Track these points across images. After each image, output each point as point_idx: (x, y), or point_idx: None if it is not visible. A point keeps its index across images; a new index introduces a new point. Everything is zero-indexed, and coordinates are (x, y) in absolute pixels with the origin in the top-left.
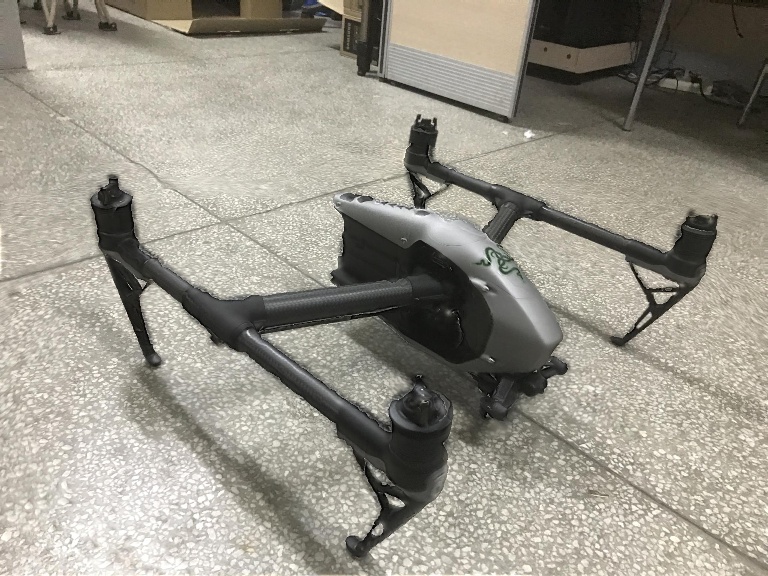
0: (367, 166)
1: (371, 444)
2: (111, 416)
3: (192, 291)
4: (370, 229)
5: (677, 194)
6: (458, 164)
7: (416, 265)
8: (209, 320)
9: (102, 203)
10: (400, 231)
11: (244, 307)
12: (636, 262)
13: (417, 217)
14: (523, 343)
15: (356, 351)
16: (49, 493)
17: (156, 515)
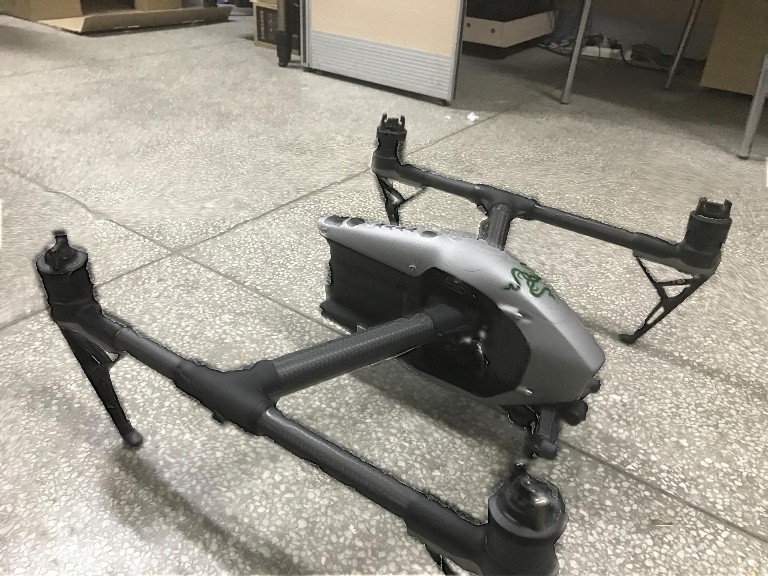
0: (316, 169)
1: (456, 543)
2: (97, 521)
3: (185, 366)
4: (368, 257)
5: (632, 167)
6: (410, 156)
7: (429, 294)
8: (216, 402)
9: (52, 268)
10: (406, 257)
11: (254, 379)
12: (645, 257)
13: (424, 240)
14: (566, 371)
15: (361, 391)
16: None
17: None
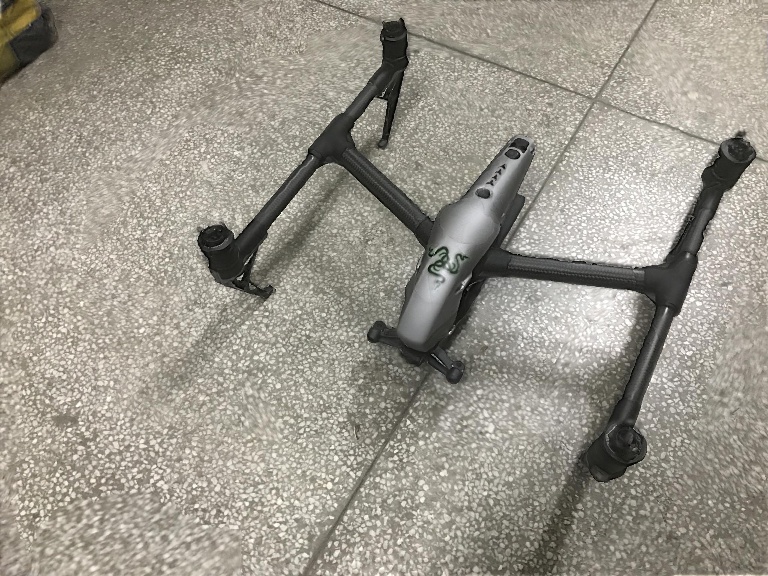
0: None
1: None
2: None
3: (343, 116)
4: None
5: None
6: None
7: None
8: None
9: None
10: None
11: (334, 144)
12: None
13: None
14: None
15: None
16: (265, 153)
17: (265, 199)
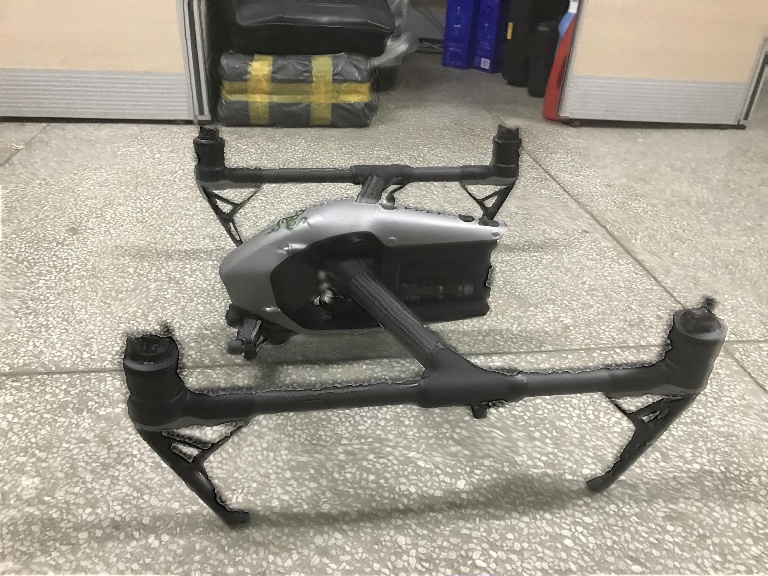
0: None
1: None
2: None
3: None
4: None
5: None
6: None
7: None
8: None
9: None
10: None
11: (373, 171)
12: None
13: None
14: None
15: None
16: None
17: None
